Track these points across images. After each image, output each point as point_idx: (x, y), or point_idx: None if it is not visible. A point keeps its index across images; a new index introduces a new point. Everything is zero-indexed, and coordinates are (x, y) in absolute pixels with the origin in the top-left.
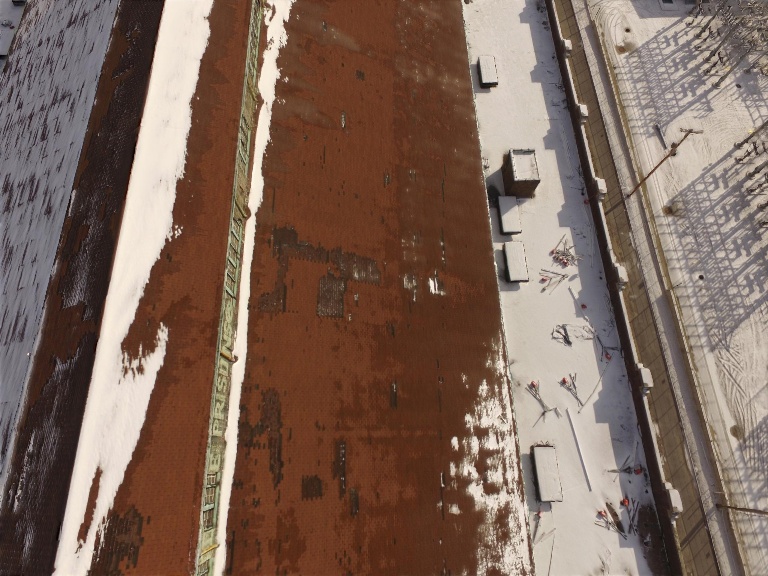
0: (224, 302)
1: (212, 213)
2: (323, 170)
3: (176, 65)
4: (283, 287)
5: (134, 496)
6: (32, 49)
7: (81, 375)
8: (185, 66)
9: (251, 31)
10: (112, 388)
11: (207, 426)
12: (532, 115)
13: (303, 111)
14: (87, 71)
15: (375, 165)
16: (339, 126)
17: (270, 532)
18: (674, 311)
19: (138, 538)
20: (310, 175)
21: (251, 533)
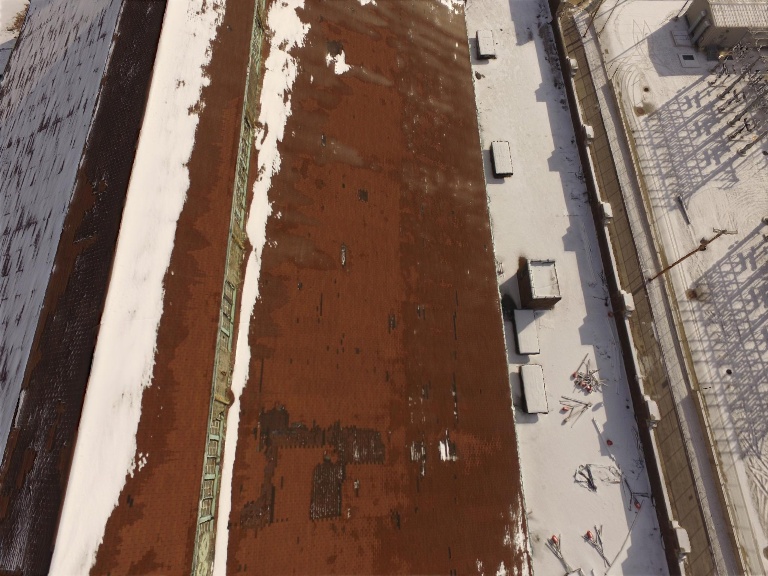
0: (197, 547)
1: (185, 426)
2: (320, 324)
3: (147, 233)
4: (271, 489)
5: None
6: (1, 149)
7: None
8: (158, 233)
9: (238, 170)
10: None
11: None
12: (550, 210)
13: (298, 252)
14: (55, 196)
15: (379, 307)
16: (338, 264)
17: None
18: (701, 416)
19: None
20: (304, 334)
21: None
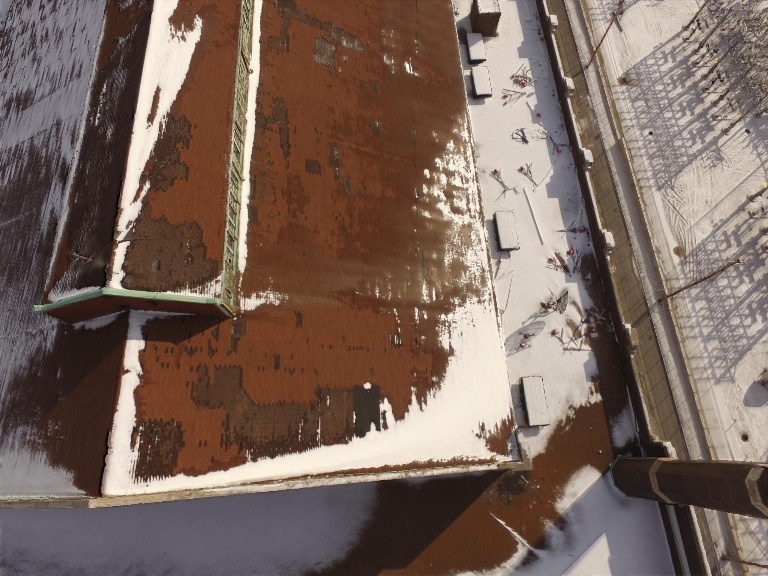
0: (242, 16)
1: None
2: None
3: None
4: (286, 36)
5: (184, 110)
6: None
7: (141, 35)
8: None
9: None
10: (164, 43)
11: (234, 87)
12: None
13: None
14: None
15: None
16: None
17: (282, 184)
18: (625, 154)
19: (189, 134)
20: None
21: (268, 180)
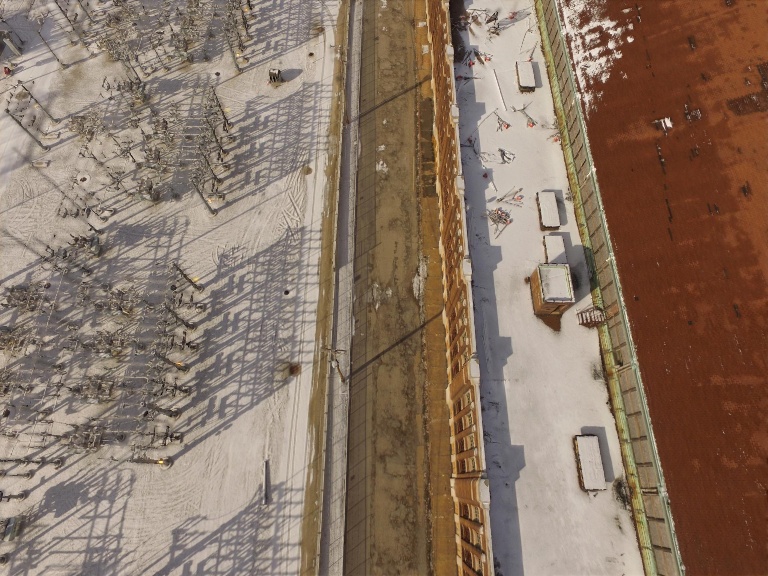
0: None
1: None
2: None
3: None
4: None
5: None
6: None
7: None
8: None
9: None
10: None
11: None
12: (525, 388)
13: None
14: None
15: (767, 198)
16: None
17: None
18: None
19: None
20: None
21: None
